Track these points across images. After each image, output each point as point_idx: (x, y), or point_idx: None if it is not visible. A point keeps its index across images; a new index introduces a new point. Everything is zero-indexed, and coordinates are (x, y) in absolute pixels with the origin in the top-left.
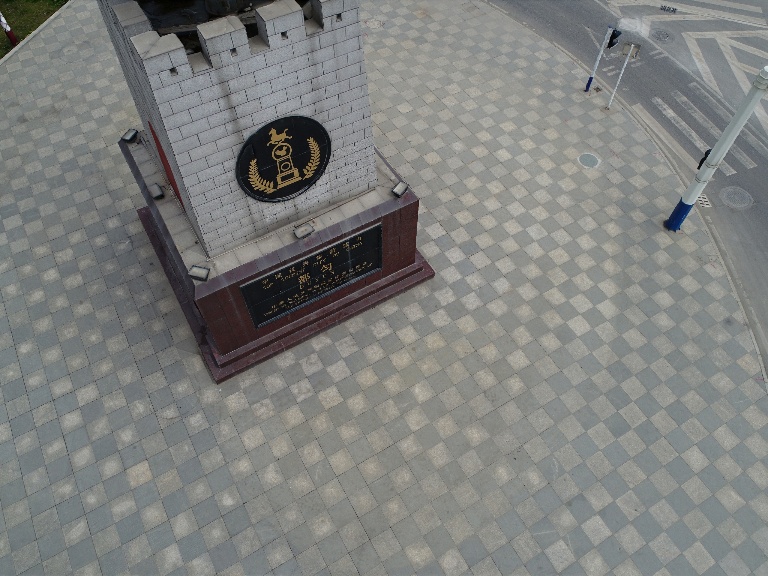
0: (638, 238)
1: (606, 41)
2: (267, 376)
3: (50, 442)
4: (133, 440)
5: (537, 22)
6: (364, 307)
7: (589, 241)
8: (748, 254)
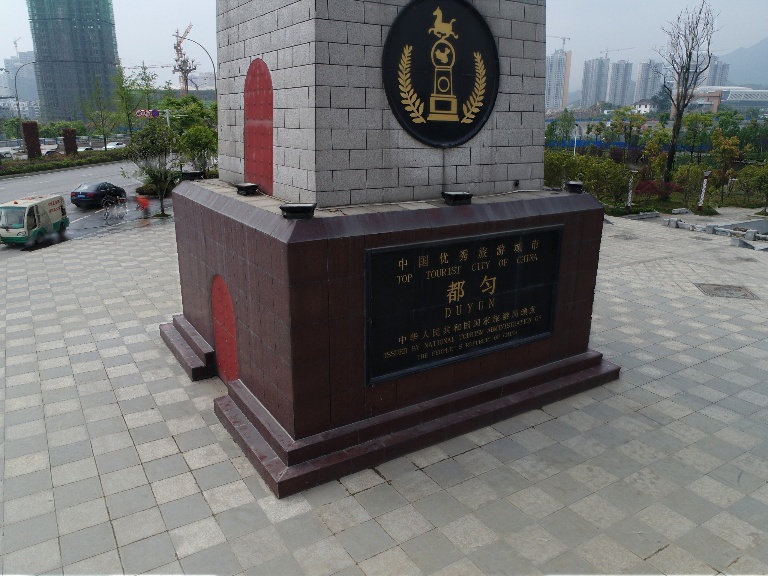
0: None
1: None
2: None
3: None
4: None
5: None
6: None
7: None
8: None
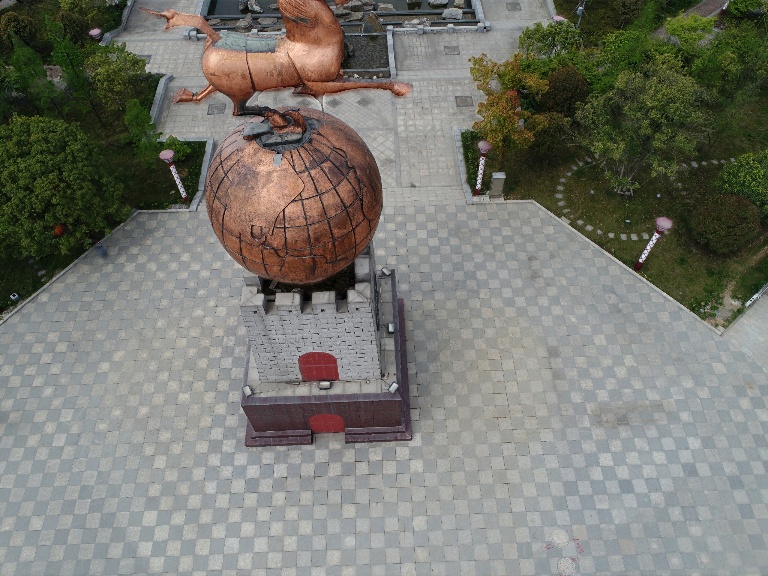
0: None
1: None
2: None
3: None
4: None
5: None
6: None
7: None
8: None
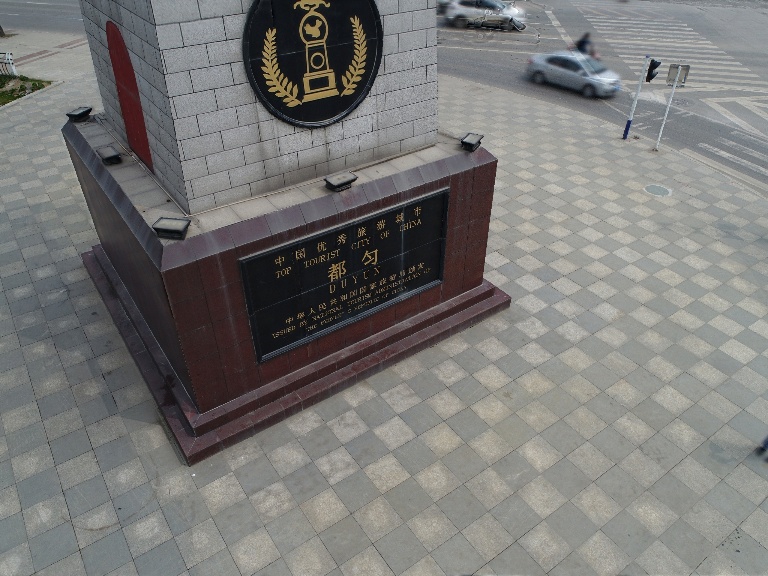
0: (759, 255)
1: (644, 74)
2: (275, 448)
3: None
4: (21, 574)
5: (546, 97)
6: (419, 342)
7: (699, 261)
8: None
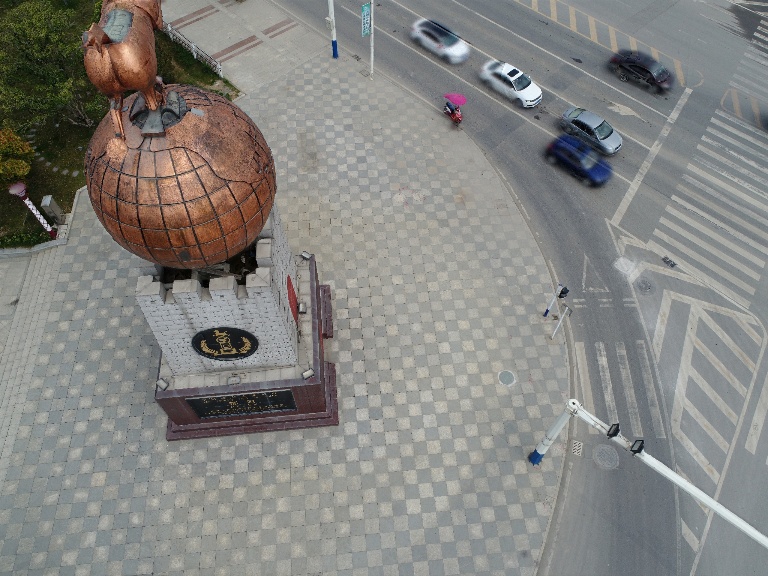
0: (501, 458)
1: (558, 292)
2: (198, 449)
3: (64, 436)
4: (106, 456)
5: (548, 236)
6: (279, 429)
7: (463, 445)
8: (581, 508)
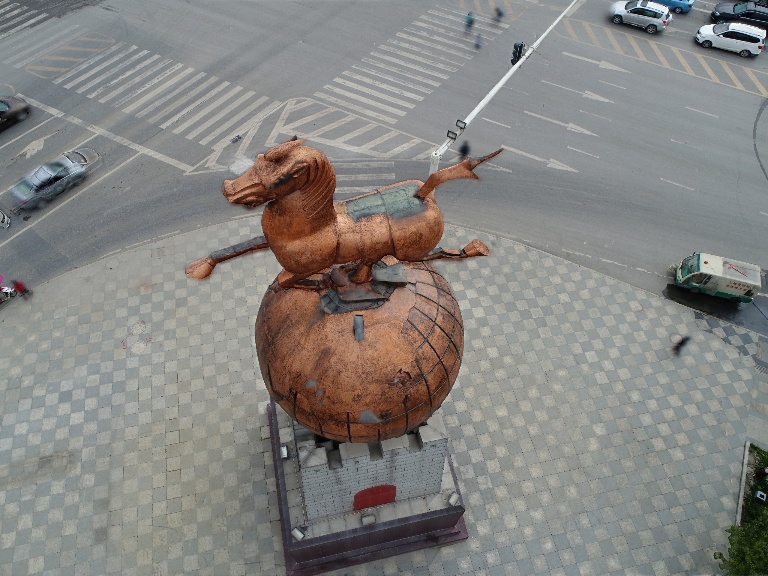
0: None
1: None
2: (469, 503)
3: None
4: None
5: (202, 218)
6: None
7: None
8: (453, 212)
